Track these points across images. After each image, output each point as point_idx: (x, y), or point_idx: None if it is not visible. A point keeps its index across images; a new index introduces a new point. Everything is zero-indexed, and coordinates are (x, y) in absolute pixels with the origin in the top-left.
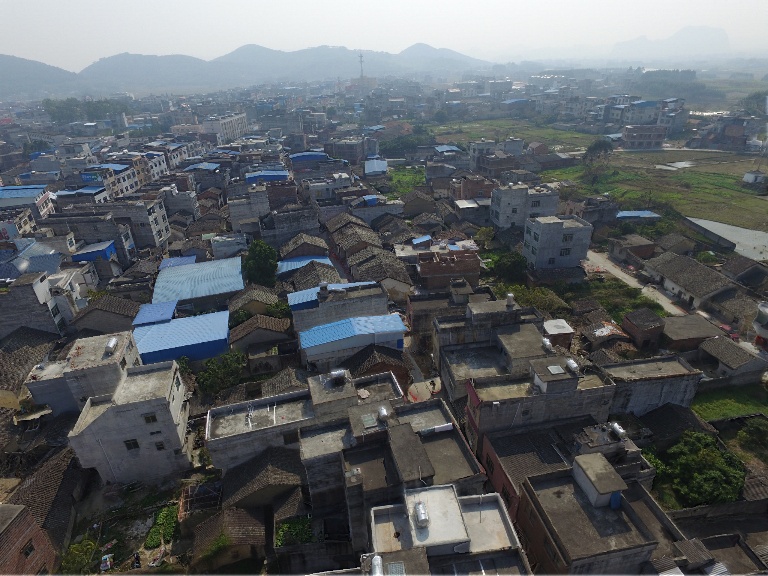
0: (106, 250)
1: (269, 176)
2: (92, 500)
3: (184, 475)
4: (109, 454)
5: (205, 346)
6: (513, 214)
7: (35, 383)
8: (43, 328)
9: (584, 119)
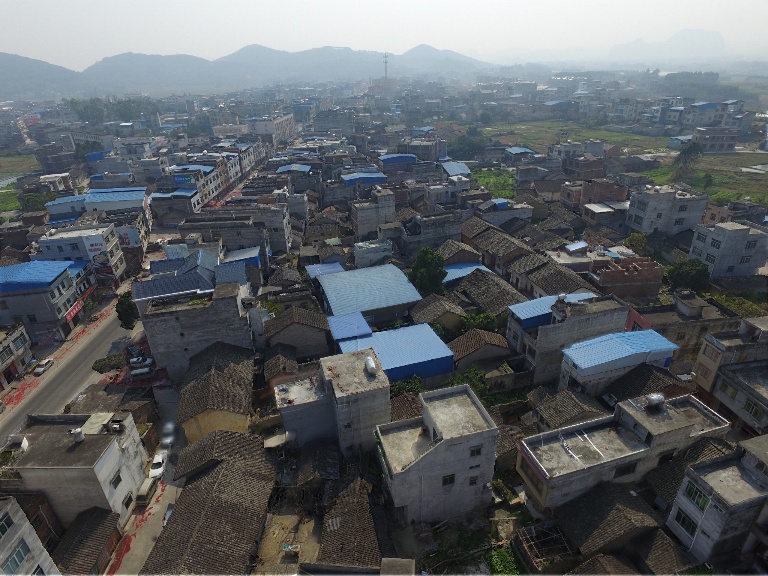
0: (257, 257)
1: (368, 178)
2: (399, 542)
3: (486, 511)
4: (424, 491)
5: (432, 363)
6: (657, 219)
7: (290, 408)
8: (238, 343)
9: (636, 121)
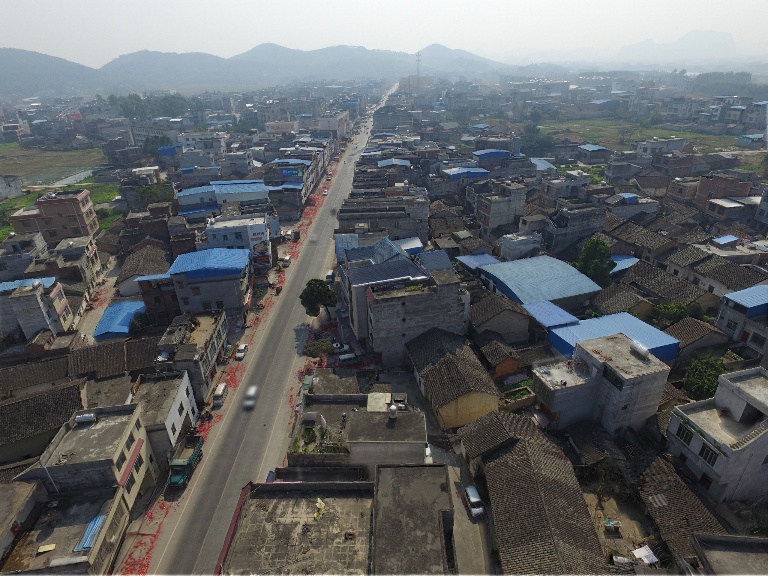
0: None
1: (472, 173)
2: None
3: None
4: (747, 469)
5: (660, 350)
6: None
7: (563, 389)
8: (450, 329)
9: (692, 120)
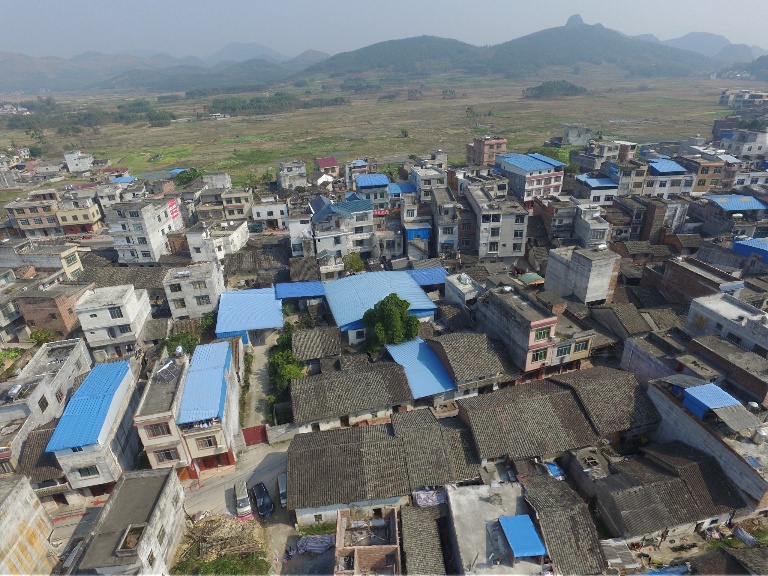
0: (409, 231)
1: None
2: None
3: None
4: None
5: None
6: None
7: None
8: None
9: None
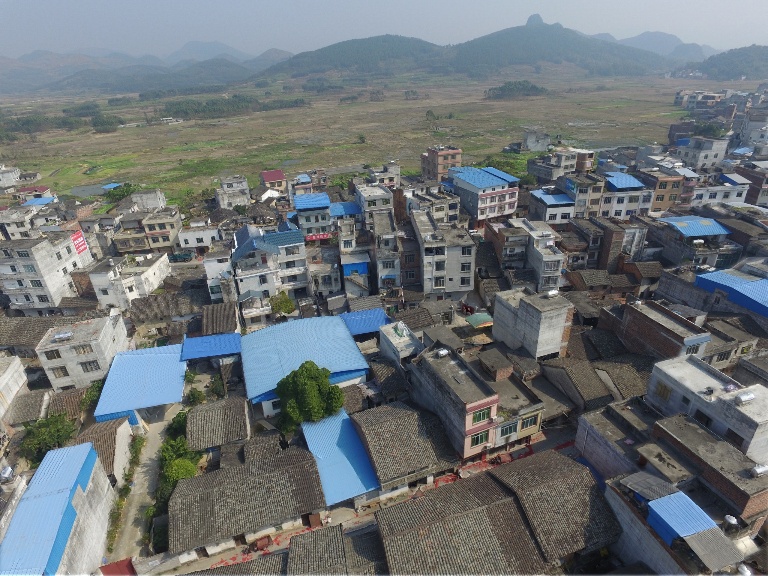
0: (345, 266)
1: (743, 296)
2: None
3: None
4: None
5: None
6: None
7: None
8: None
9: None
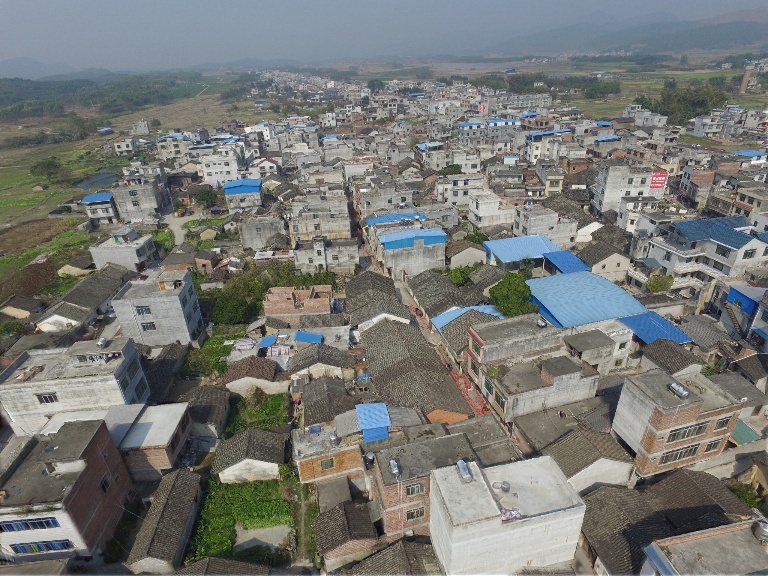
0: (732, 290)
1: None
2: None
3: None
4: None
5: None
6: None
7: None
8: None
9: None
